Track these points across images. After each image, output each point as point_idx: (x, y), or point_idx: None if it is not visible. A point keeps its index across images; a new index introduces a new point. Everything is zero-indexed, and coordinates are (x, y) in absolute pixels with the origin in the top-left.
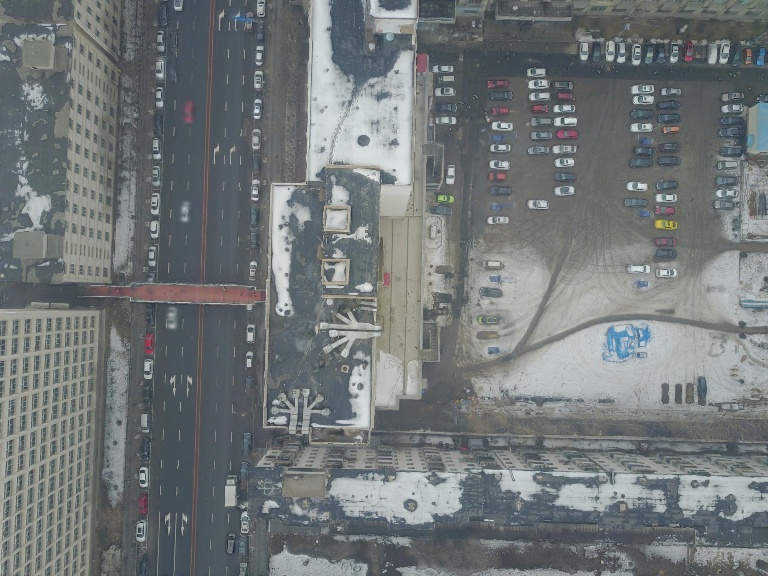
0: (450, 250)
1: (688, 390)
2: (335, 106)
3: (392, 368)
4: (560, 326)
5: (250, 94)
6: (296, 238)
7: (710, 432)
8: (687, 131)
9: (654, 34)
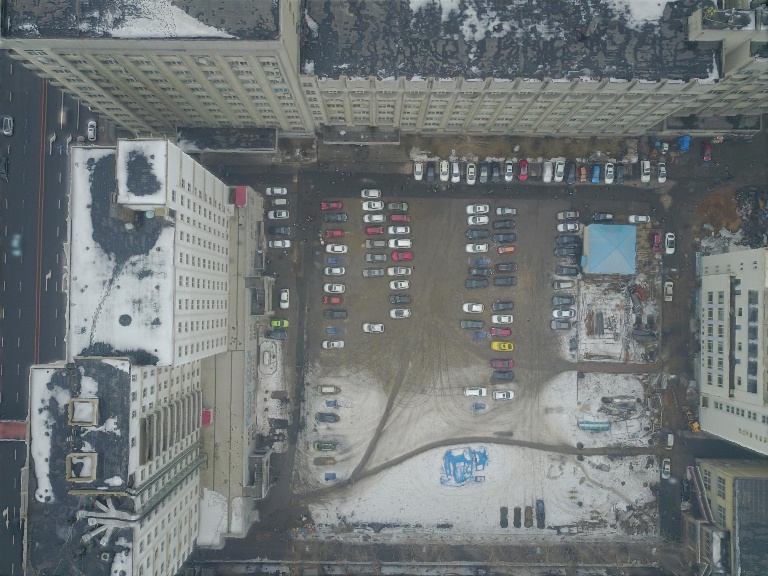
0: (286, 375)
1: (527, 513)
2: (95, 285)
3: (216, 505)
4: (397, 450)
5: None
6: (56, 422)
7: (549, 556)
8: (523, 250)
9: (489, 152)
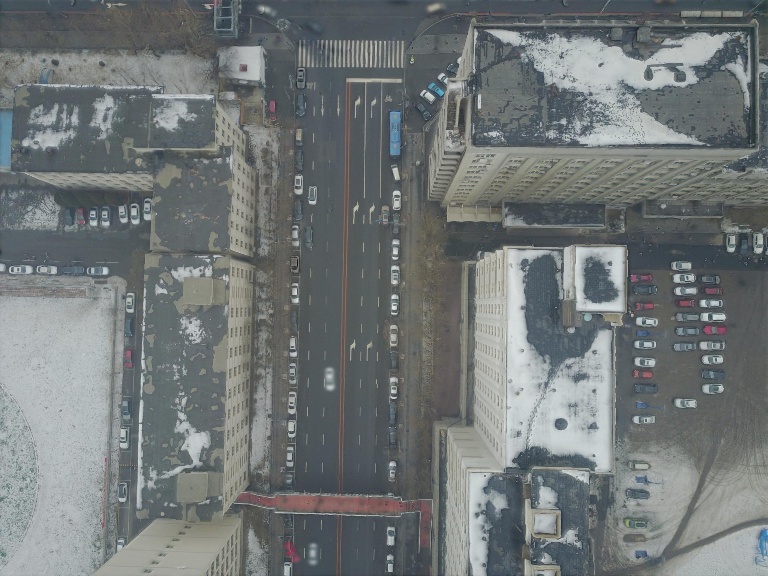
0: None
1: None
2: (531, 388)
3: None
4: (710, 529)
5: (386, 288)
6: (493, 527)
7: None
8: None
9: None
